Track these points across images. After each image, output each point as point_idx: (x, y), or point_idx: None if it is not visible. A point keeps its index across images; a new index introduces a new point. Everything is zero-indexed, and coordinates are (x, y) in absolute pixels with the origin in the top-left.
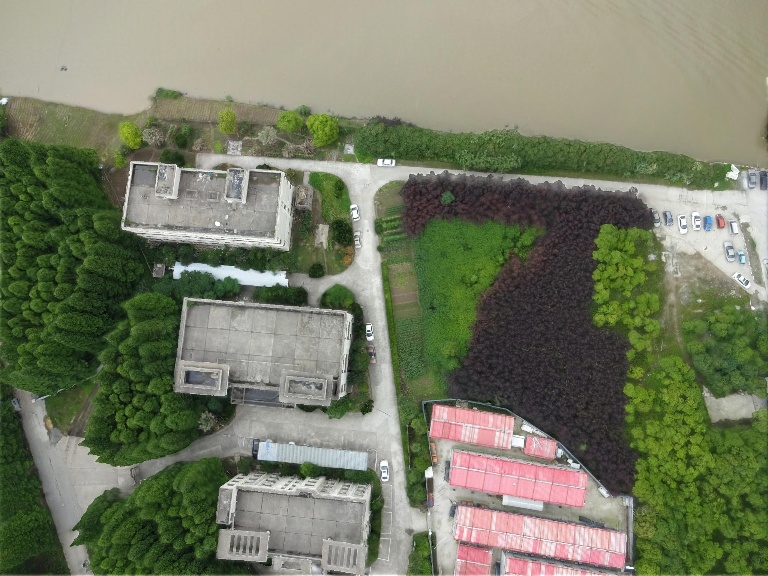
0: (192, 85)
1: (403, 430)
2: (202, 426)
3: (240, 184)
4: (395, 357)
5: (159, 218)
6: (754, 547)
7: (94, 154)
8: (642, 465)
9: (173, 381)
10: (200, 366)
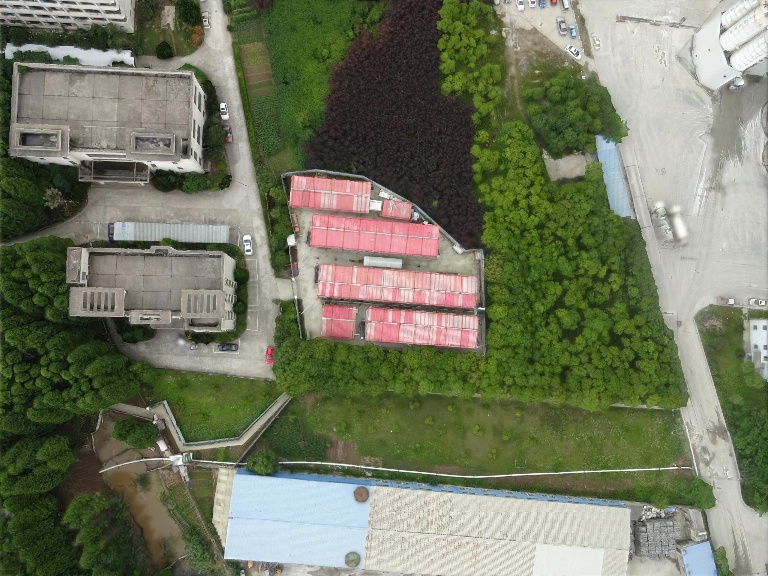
0: None
1: (264, 204)
2: (48, 203)
3: None
4: (251, 134)
5: None
6: (588, 282)
7: None
8: (489, 215)
9: (8, 147)
10: (37, 128)
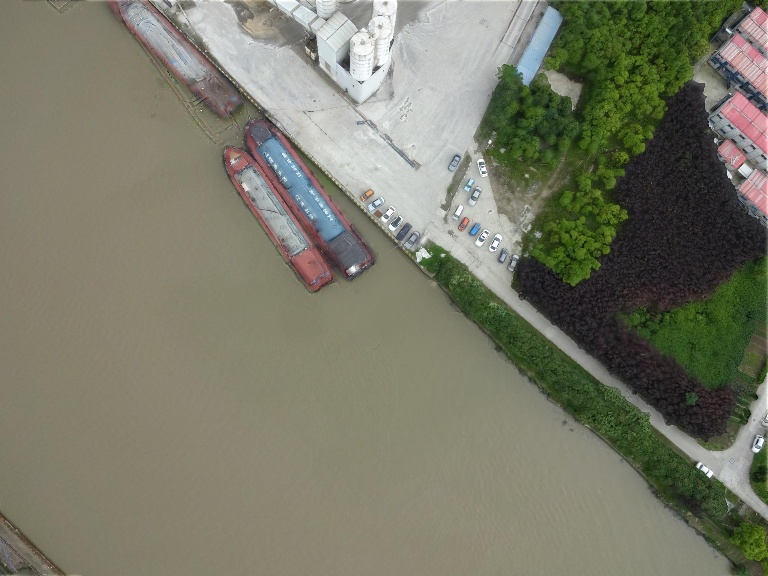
0: None
1: None
2: None
3: None
4: None
5: None
6: None
7: None
8: (674, 90)
9: None
10: None
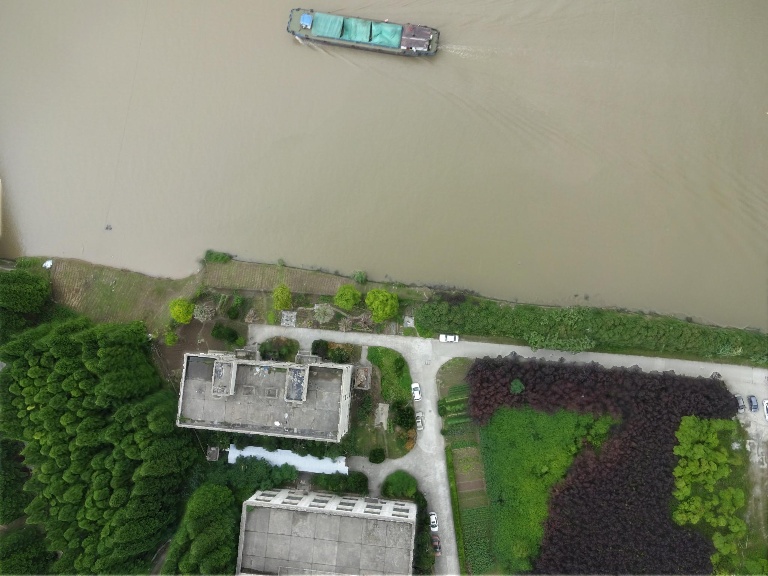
0: (242, 246)
1: None
2: None
3: (300, 384)
4: (461, 551)
5: (215, 414)
6: None
7: (144, 329)
8: None
9: None
10: None
